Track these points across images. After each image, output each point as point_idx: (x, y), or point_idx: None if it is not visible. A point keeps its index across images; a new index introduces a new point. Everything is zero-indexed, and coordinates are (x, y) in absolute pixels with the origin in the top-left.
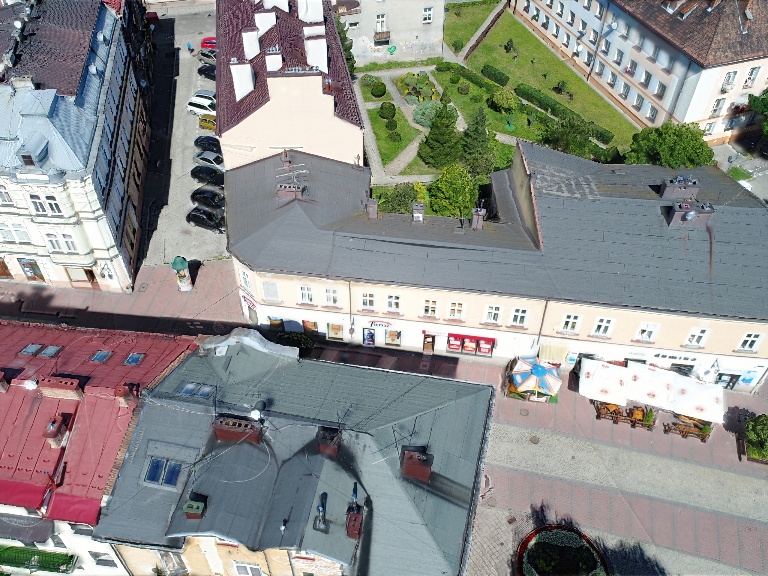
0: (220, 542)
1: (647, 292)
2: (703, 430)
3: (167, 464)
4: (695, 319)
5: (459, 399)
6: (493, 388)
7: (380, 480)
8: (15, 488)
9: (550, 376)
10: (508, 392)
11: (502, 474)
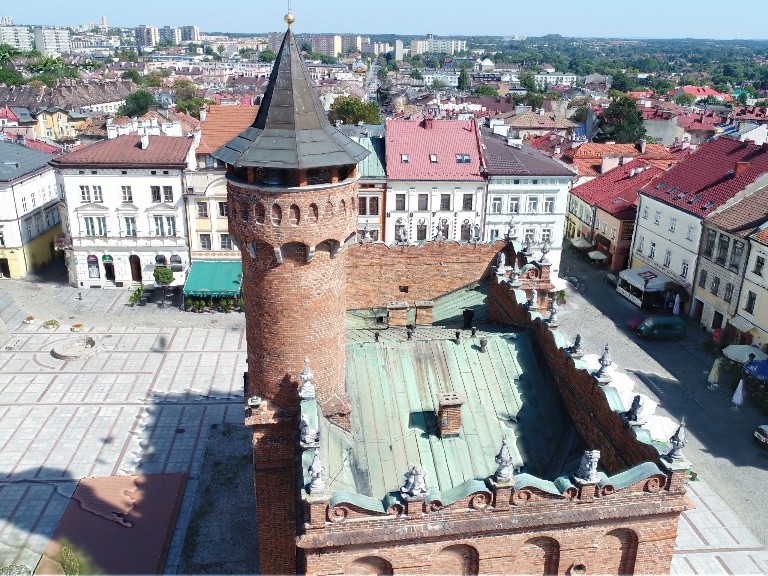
0: None
1: None
2: None
3: None
4: None
5: None
6: None
7: None
8: None
9: None
10: None
11: None
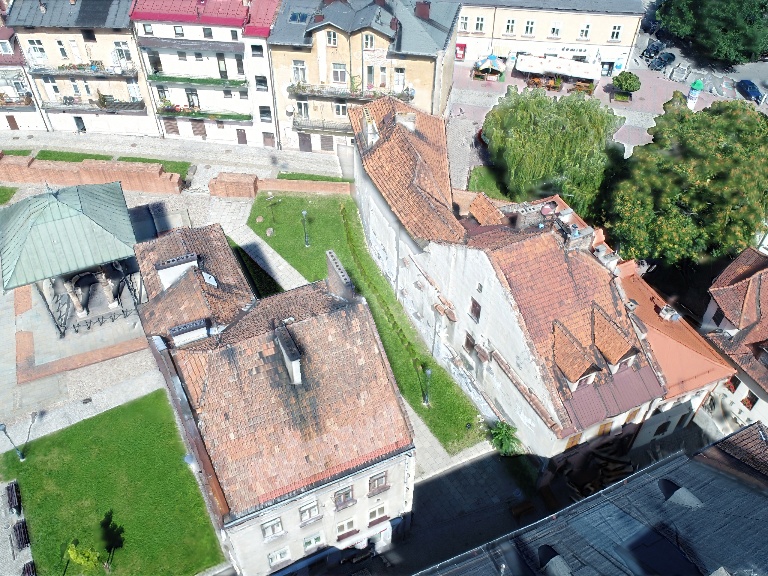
0: (328, 45)
1: (554, 1)
2: (589, 87)
3: (300, 14)
4: (582, 16)
5: (443, 2)
6: (461, 4)
7: (405, 16)
8: (229, 20)
9: (499, 61)
10: (474, 76)
11: (470, 108)
